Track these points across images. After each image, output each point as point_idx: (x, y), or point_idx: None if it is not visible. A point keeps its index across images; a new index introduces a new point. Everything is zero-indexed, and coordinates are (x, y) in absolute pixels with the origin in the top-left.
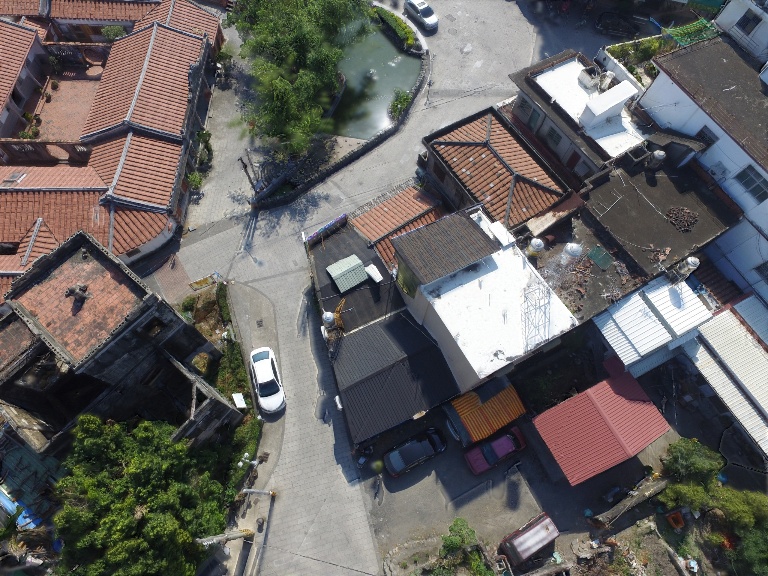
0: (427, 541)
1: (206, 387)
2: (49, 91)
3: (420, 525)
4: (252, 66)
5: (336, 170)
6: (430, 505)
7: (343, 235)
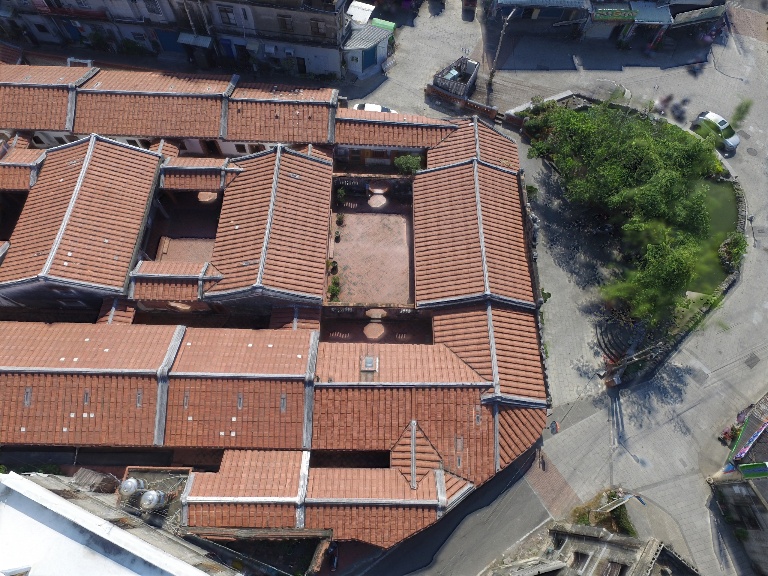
0: None
1: None
2: (335, 227)
3: None
4: (545, 194)
5: (686, 334)
6: None
7: None
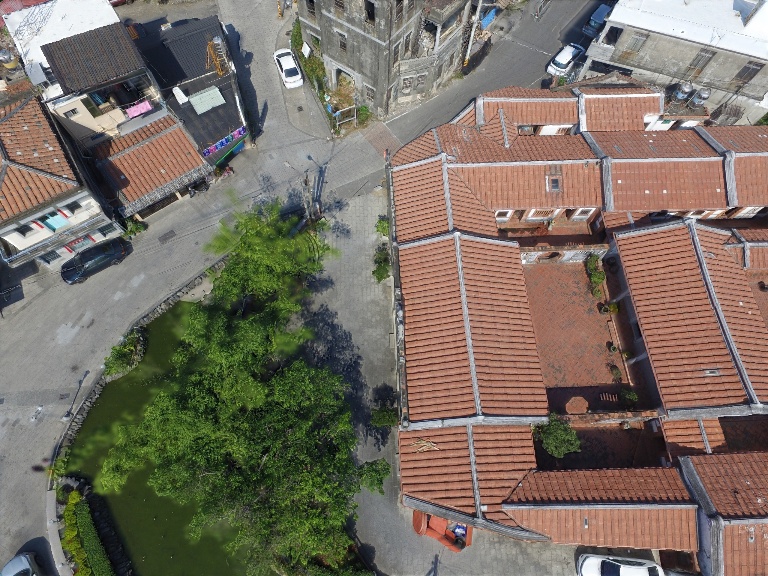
0: (183, 0)
1: (310, 5)
2: (618, 362)
3: (186, 8)
4: None
5: None
6: (177, 16)
7: (210, 140)
